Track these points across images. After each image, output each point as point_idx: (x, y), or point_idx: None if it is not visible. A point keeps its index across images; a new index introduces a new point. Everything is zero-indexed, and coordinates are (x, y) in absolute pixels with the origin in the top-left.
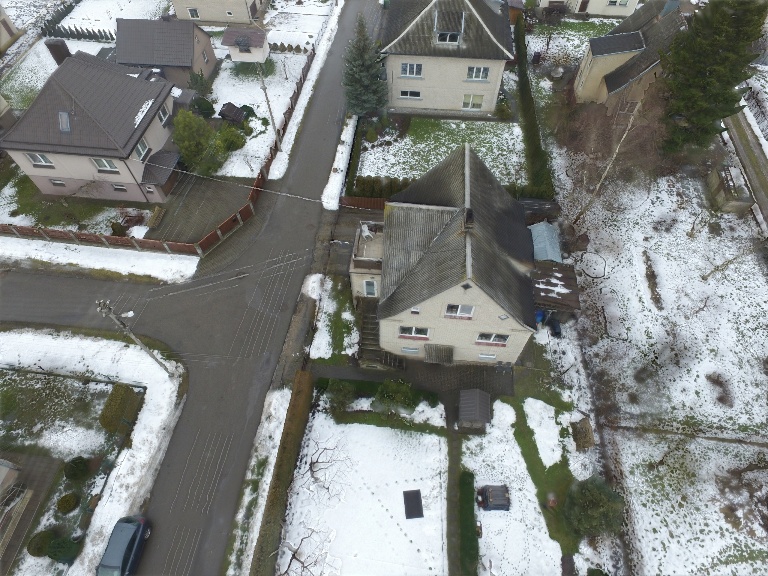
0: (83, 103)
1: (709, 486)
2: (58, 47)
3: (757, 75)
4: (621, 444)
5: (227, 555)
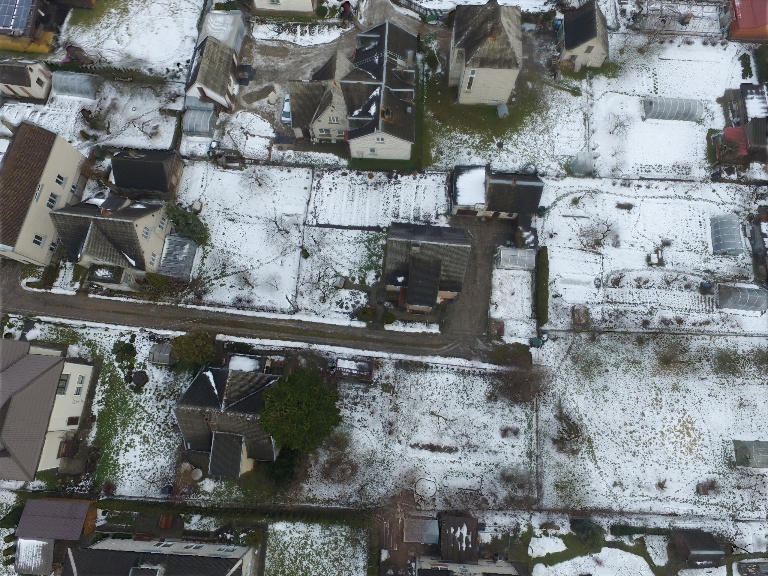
0: None
1: (562, 457)
2: None
3: (205, 283)
4: (547, 500)
5: None
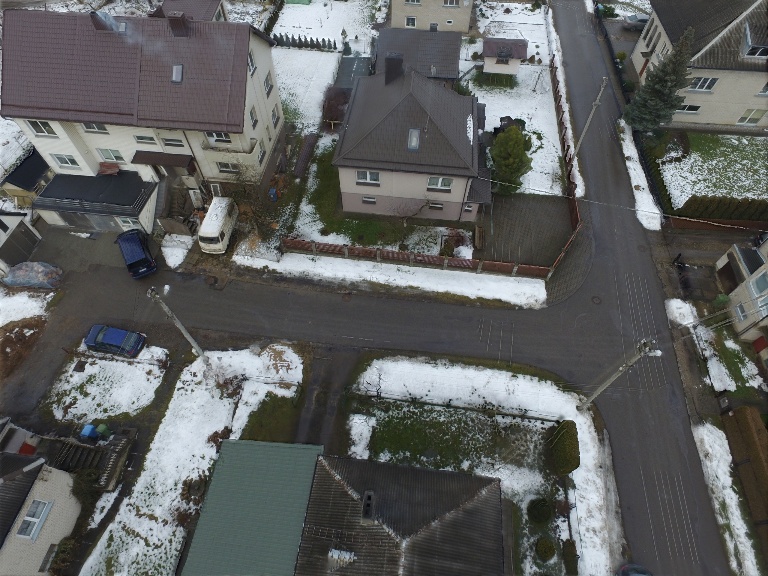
0: (436, 120)
1: None
2: (399, 61)
3: None
4: None
5: None
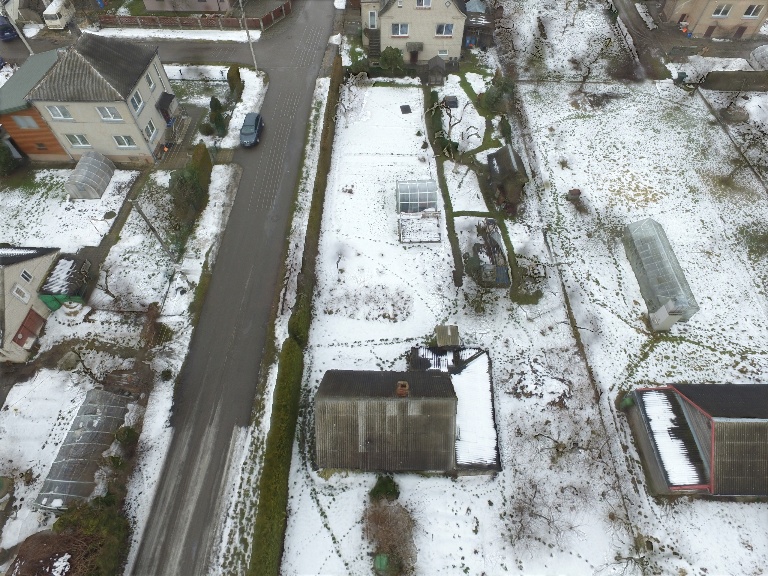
0: None
1: (565, 97)
2: None
3: None
4: (519, 86)
5: (308, 129)
